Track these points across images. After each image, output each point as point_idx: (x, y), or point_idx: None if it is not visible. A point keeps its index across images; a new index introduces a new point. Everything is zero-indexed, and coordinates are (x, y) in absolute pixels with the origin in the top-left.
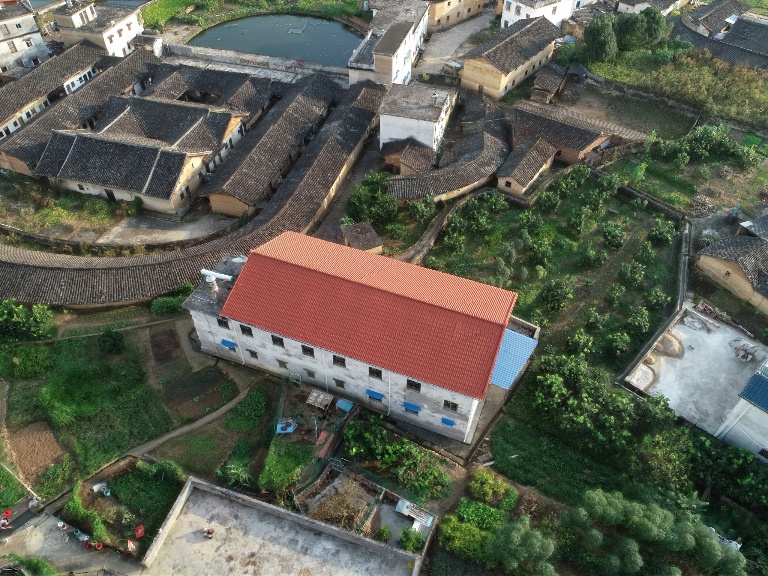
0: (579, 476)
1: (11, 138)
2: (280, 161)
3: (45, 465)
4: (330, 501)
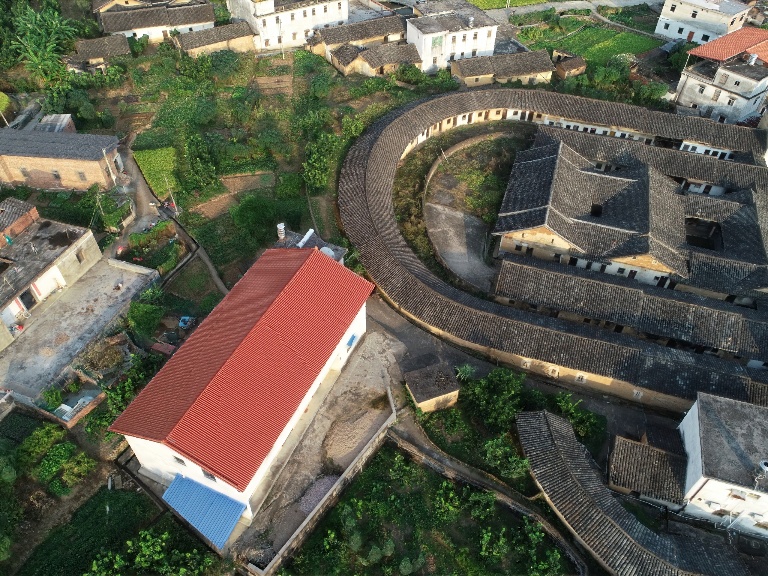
0: (59, 571)
1: (555, 128)
2: (584, 310)
3: (204, 213)
4: (110, 350)
